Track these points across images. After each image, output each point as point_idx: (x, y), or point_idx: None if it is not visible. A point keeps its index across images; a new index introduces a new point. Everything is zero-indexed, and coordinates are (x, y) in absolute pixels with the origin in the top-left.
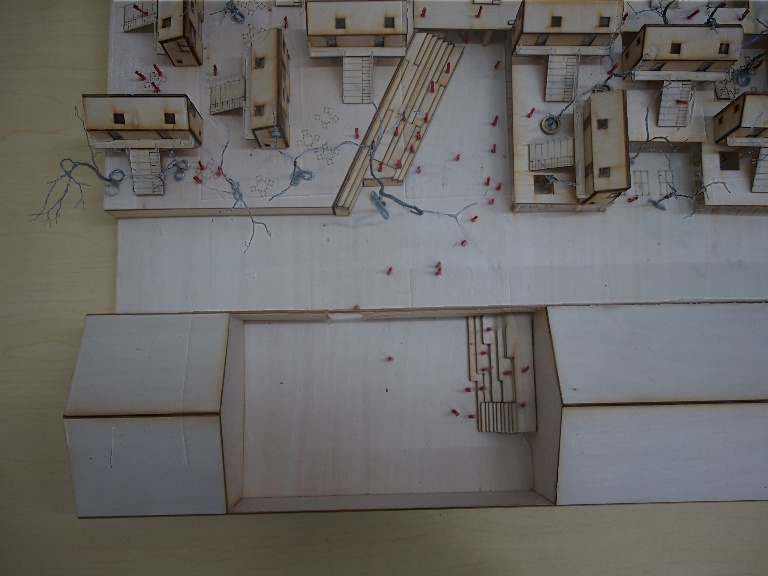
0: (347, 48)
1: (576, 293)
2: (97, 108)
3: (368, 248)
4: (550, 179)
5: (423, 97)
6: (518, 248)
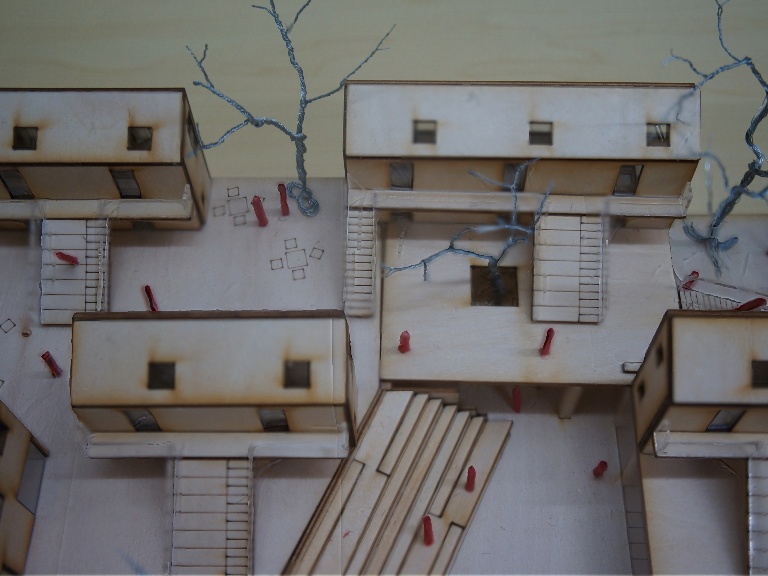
0: (189, 435)
1: None
2: None
3: None
4: None
5: (403, 557)
6: None
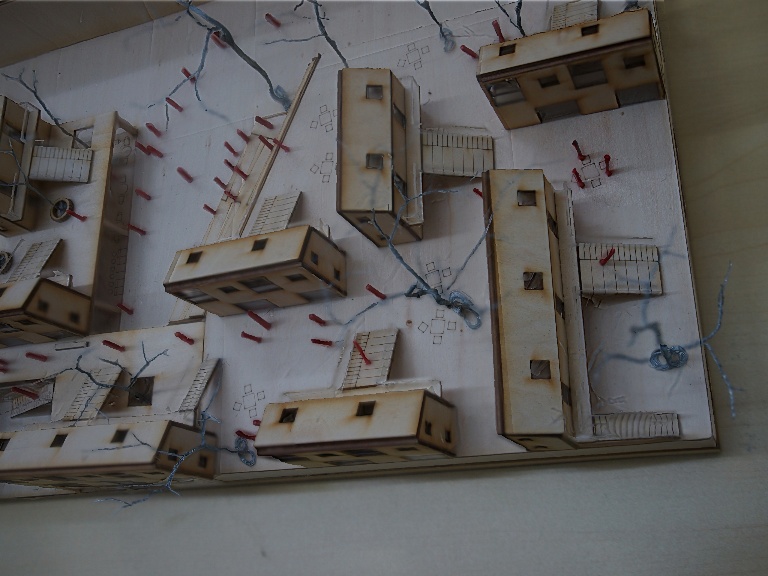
0: None
1: (89, 58)
2: (625, 30)
3: (301, 47)
4: (35, 82)
5: None
6: (138, 90)
